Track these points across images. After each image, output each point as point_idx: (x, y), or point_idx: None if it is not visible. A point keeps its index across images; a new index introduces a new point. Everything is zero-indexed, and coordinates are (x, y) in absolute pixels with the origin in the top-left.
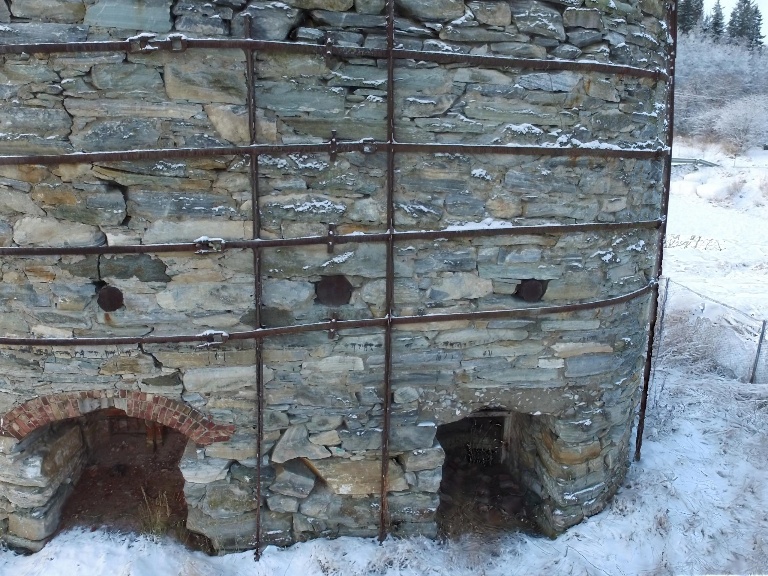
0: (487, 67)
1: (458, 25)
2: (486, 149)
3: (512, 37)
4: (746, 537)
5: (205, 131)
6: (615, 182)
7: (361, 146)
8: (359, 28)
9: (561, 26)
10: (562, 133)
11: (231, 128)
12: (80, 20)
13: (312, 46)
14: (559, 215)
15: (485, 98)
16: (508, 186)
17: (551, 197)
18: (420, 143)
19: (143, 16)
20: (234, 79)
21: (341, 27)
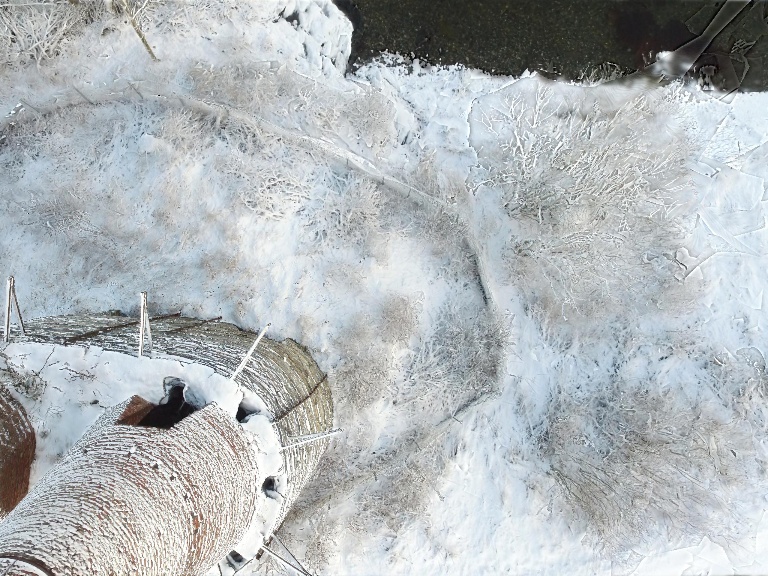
0: None
1: None
2: None
3: None
4: (53, 289)
5: None
6: None
7: None
8: None
9: None
10: None
11: None
12: None
13: None
14: None
15: None
16: None
17: None
18: (116, 324)
19: None
20: None
21: None
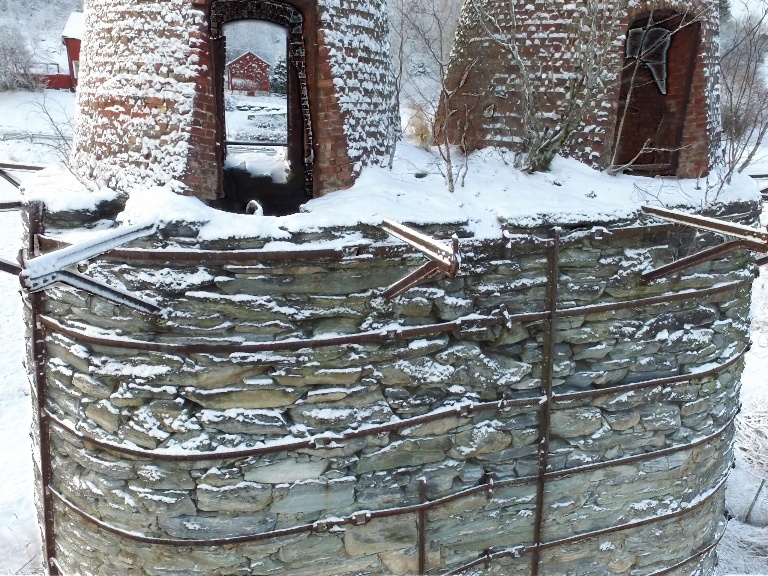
0: (618, 464)
1: (597, 438)
2: (614, 530)
3: (640, 436)
4: None
5: (380, 574)
6: (707, 515)
7: (513, 554)
8: (514, 458)
9: (678, 416)
10: (673, 499)
11: (402, 565)
12: (266, 506)
13: (477, 489)
14: (666, 560)
15: (614, 488)
16: (627, 549)
17: (661, 549)
18: (561, 539)
19: (329, 500)
20: (407, 528)
21: (499, 462)
